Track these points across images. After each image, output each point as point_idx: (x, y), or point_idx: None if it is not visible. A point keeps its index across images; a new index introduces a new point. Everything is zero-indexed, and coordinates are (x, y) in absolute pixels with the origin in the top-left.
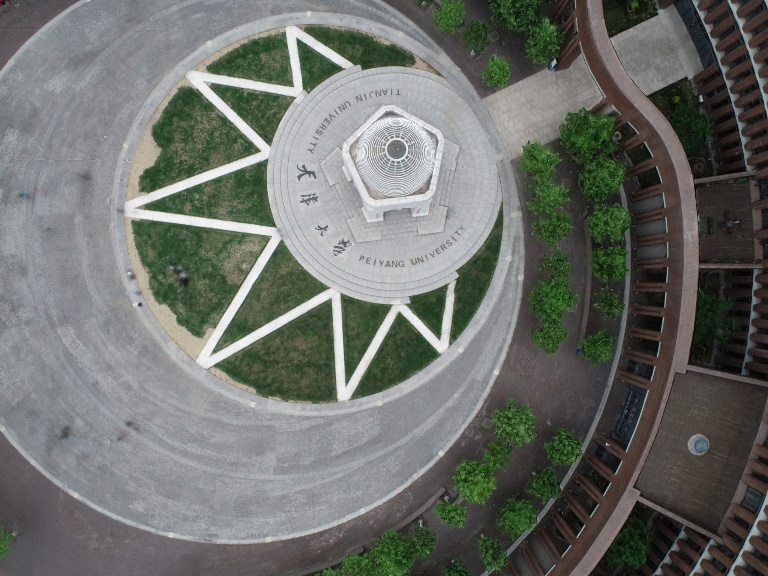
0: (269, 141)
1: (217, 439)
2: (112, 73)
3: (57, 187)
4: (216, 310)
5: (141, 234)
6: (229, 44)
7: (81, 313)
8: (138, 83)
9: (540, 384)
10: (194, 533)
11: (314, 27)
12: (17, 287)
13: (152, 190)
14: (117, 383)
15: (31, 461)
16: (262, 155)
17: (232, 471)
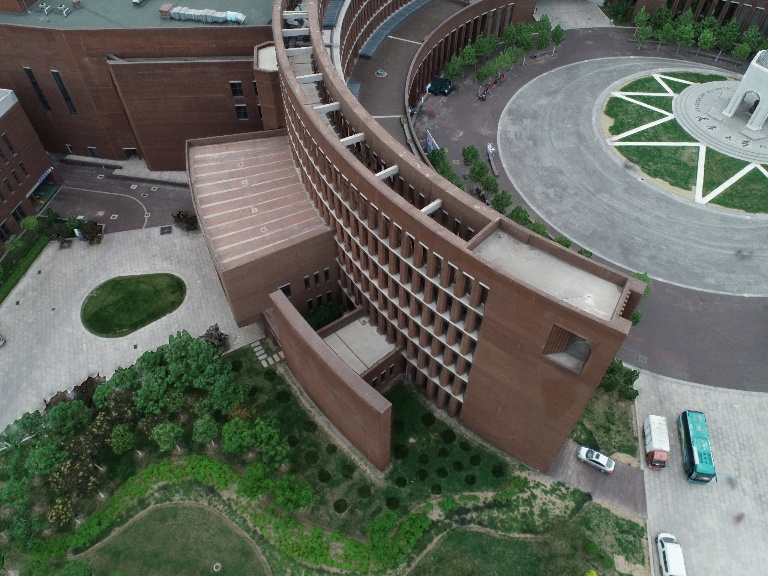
0: (670, 112)
1: (738, 237)
2: (571, 96)
3: (563, 137)
4: (691, 178)
5: (623, 151)
6: (626, 82)
7: (607, 187)
8: (587, 98)
9: None
10: (762, 292)
11: (666, 73)
12: (561, 179)
13: (618, 134)
14: (651, 217)
15: (616, 264)
16: (670, 117)
17: (762, 253)
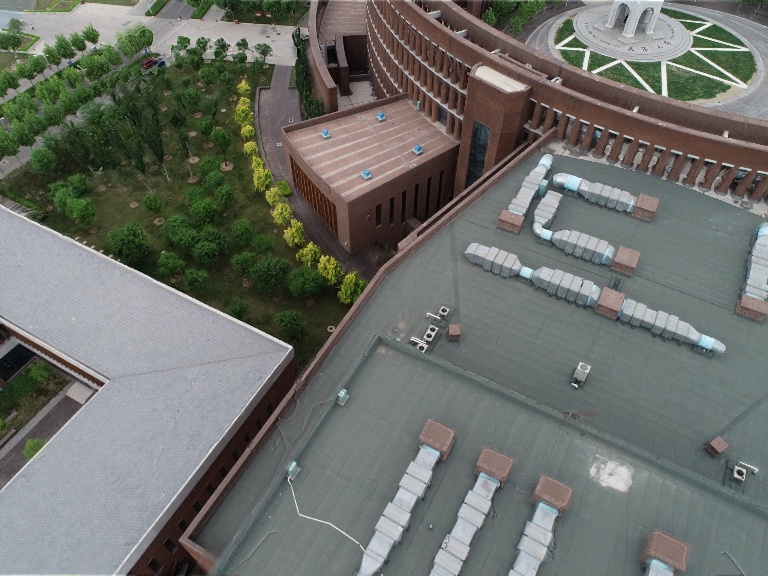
0: None
1: None
2: None
3: None
4: None
5: None
6: None
7: None
8: None
9: (719, 2)
10: None
11: None
12: None
13: None
14: None
15: None
16: (623, 62)
17: None
